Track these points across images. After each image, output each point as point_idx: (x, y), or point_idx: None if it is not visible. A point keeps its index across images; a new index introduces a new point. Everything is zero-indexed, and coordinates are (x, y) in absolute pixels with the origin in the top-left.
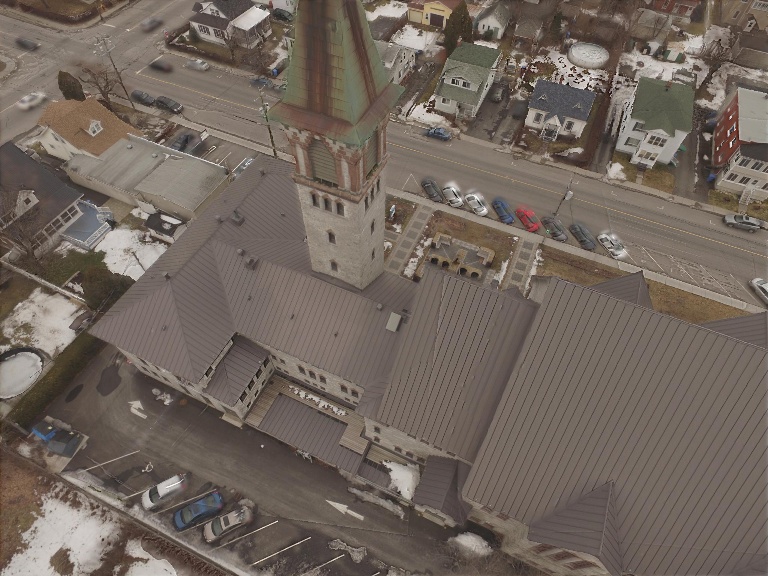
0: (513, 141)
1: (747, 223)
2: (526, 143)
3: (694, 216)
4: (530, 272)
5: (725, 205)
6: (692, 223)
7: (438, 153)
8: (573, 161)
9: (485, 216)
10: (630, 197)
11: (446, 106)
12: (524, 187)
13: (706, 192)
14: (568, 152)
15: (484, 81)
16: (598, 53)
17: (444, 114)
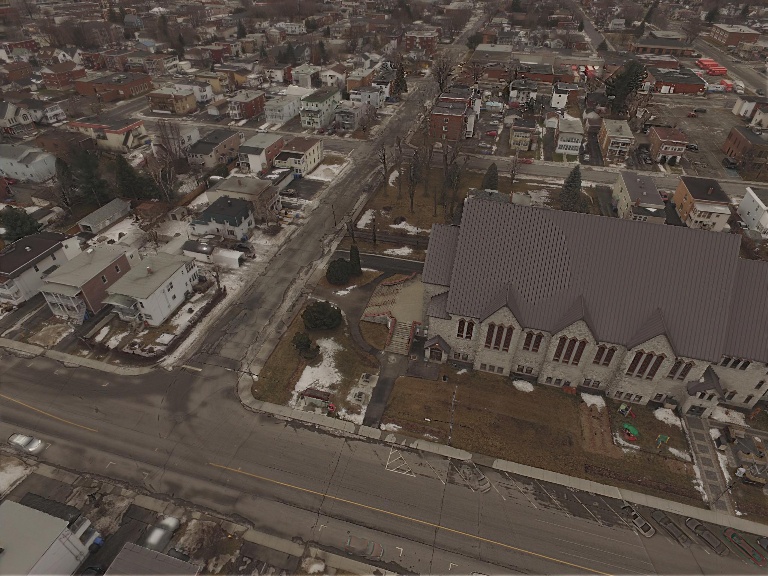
0: None
1: (488, 575)
2: None
3: None
4: (699, 469)
5: None
6: None
7: None
8: None
9: None
10: None
11: None
12: None
13: None
14: None
15: None
16: None
17: None
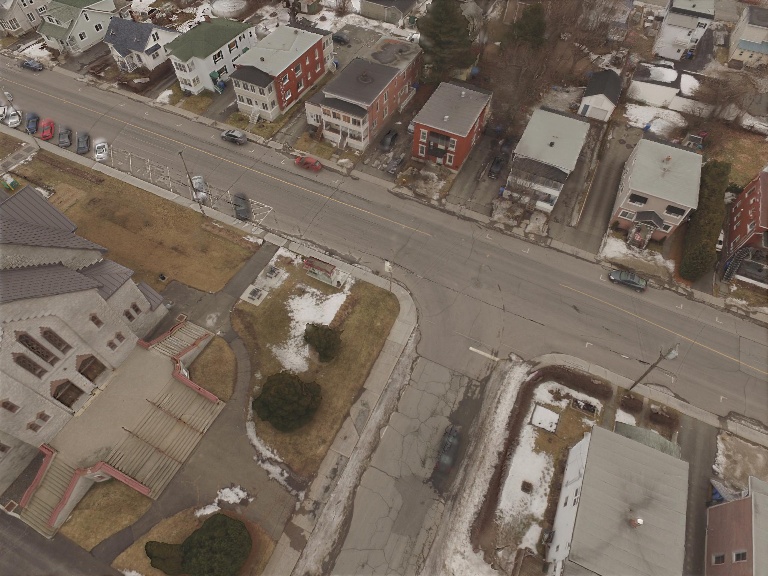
0: (96, 72)
1: (231, 136)
2: (105, 74)
3: (202, 132)
4: (9, 168)
5: (236, 124)
6: (194, 137)
7: (20, 80)
8: (131, 88)
9: (15, 128)
10: (159, 116)
11: (52, 43)
12: (70, 107)
13: (230, 114)
14: (134, 81)
15: (74, 19)
16: (237, 4)
17: (53, 50)
